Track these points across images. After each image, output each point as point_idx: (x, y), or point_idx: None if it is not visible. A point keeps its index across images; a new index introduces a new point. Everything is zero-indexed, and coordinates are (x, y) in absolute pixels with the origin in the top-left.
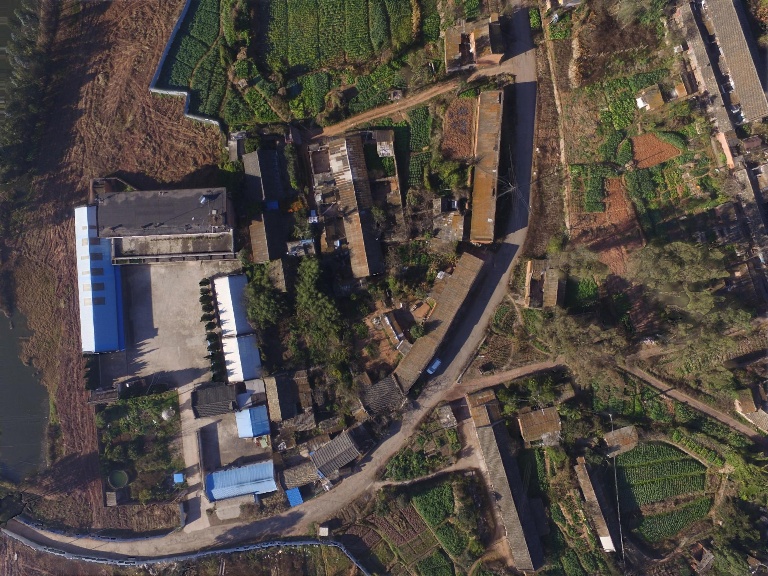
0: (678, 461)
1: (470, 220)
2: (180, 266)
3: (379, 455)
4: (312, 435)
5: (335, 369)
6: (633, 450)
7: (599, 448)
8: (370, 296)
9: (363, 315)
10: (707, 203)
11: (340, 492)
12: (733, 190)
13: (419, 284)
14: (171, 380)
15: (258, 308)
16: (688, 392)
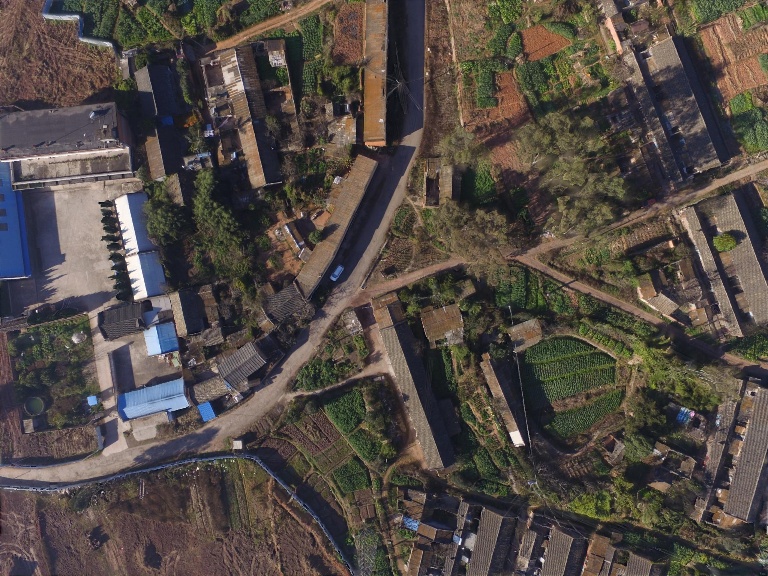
0: (587, 355)
1: (363, 122)
2: (83, 191)
3: (289, 366)
4: (222, 350)
5: (238, 281)
6: (540, 346)
7: (504, 344)
8: (269, 206)
9: (265, 227)
10: (599, 91)
11: (253, 405)
12: (621, 74)
13: (316, 190)
14: (81, 305)
15: (156, 222)
16: (590, 283)
